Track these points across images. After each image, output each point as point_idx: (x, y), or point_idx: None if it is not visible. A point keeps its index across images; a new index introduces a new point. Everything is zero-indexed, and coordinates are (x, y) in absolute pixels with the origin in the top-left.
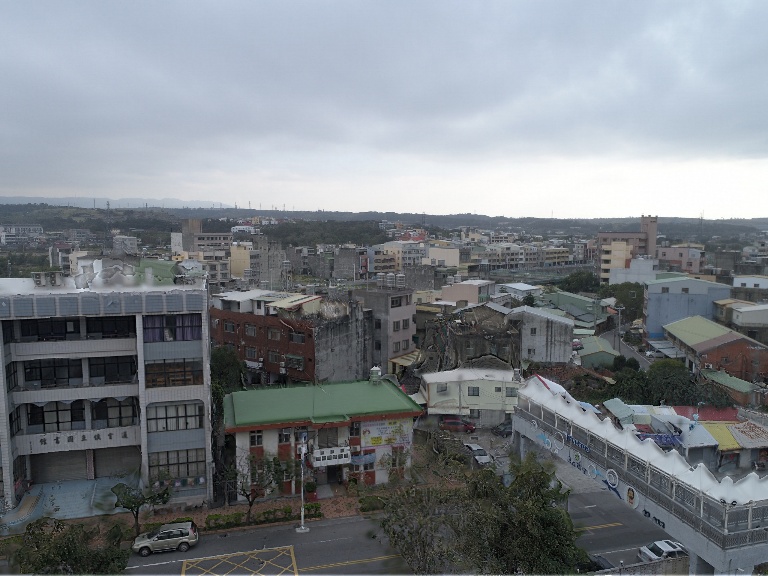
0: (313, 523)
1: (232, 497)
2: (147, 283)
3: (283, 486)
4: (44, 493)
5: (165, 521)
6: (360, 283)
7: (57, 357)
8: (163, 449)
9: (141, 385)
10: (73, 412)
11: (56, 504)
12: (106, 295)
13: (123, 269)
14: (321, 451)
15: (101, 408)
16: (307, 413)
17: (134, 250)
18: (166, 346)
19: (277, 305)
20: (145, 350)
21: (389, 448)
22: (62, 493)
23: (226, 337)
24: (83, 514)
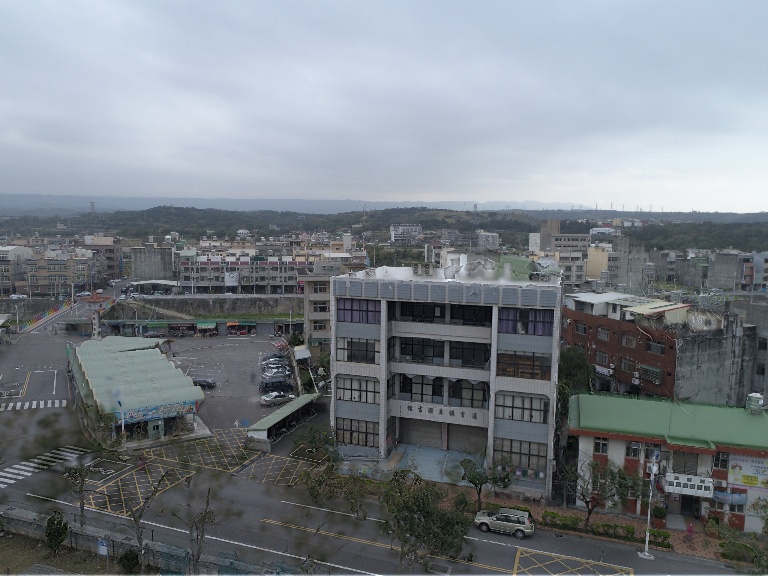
0: (659, 552)
1: (571, 500)
2: (505, 278)
3: (627, 503)
4: (407, 452)
5: (504, 505)
6: (742, 293)
7: (426, 337)
8: (507, 436)
9: (492, 372)
10: (434, 387)
11: (415, 464)
12: (469, 285)
13: (485, 263)
14: (675, 476)
15: (457, 388)
16: (661, 430)
17: (495, 246)
18: (518, 338)
19: (635, 310)
20: (498, 340)
21: (767, 493)
22: (421, 456)
23: (576, 338)
24: (436, 479)
